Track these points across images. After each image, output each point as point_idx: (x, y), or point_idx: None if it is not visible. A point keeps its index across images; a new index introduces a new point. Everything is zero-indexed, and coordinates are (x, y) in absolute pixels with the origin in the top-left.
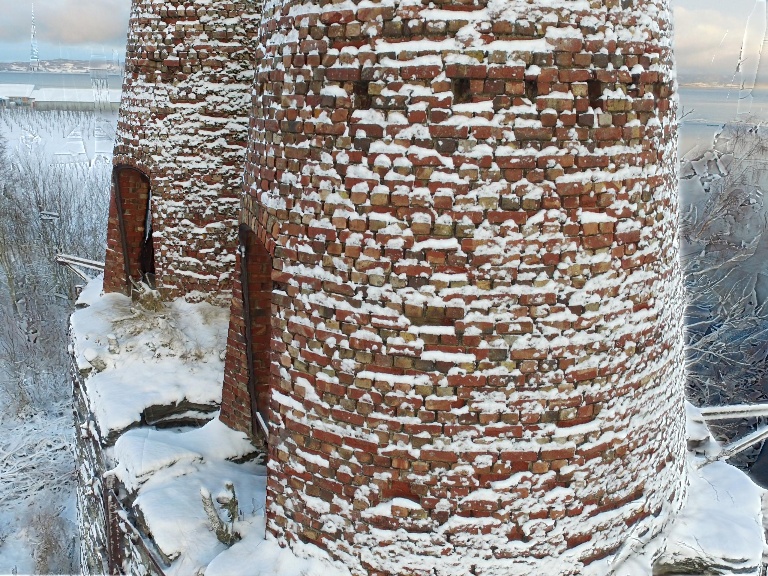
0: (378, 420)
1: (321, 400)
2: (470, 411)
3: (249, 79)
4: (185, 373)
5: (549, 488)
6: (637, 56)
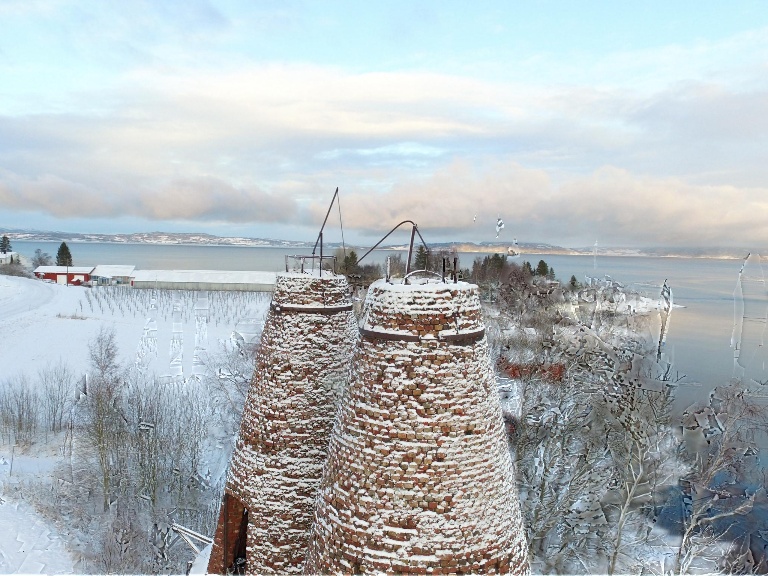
0: None
1: None
2: None
3: (313, 455)
4: None
5: None
6: (483, 555)
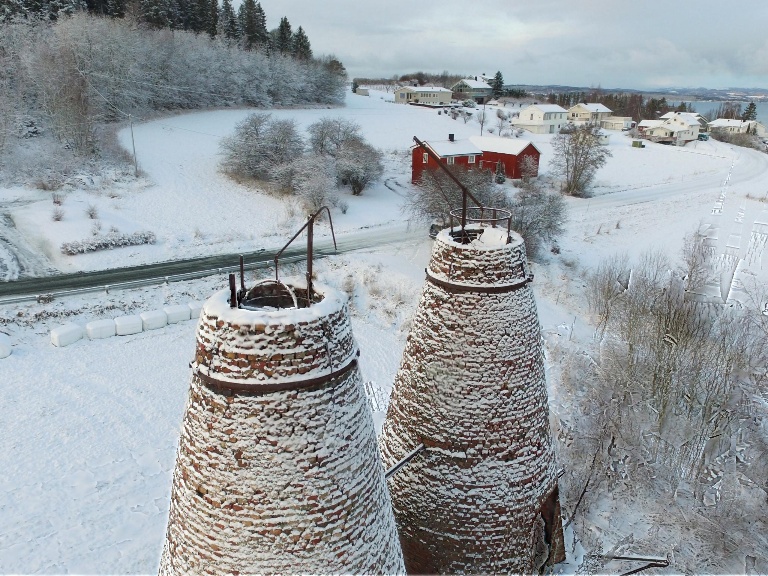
0: None
1: None
2: None
3: None
4: None
5: None
6: None
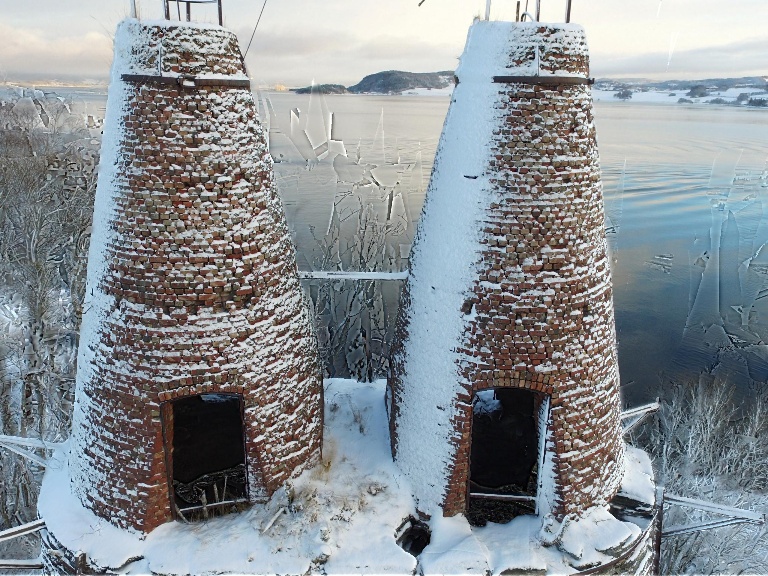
0: None
1: (586, 443)
2: None
3: None
4: (374, 517)
5: None
6: None
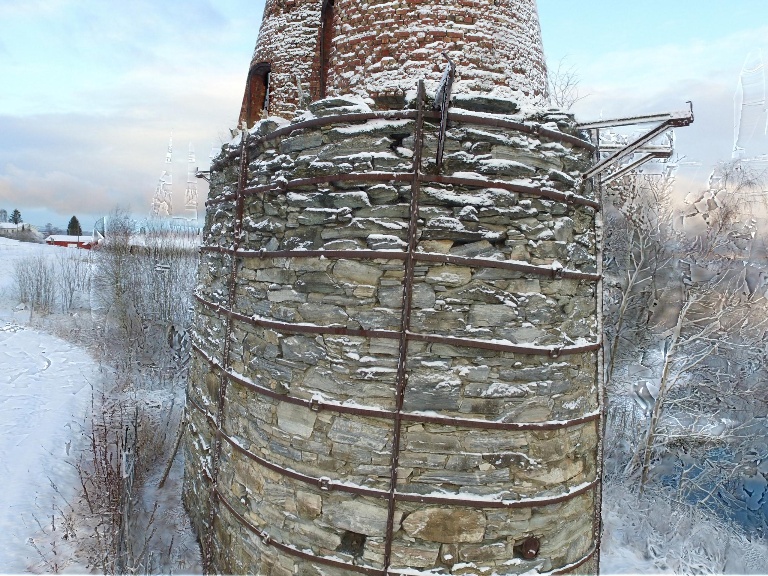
0: (377, 24)
1: (353, 27)
2: (415, 14)
3: None
4: None
5: (452, 50)
6: None
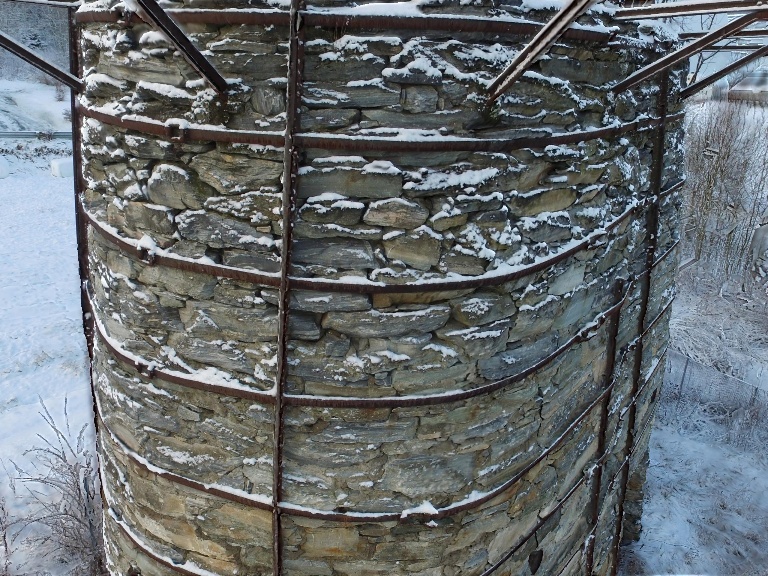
0: None
1: None
2: None
3: None
4: None
5: None
6: None
